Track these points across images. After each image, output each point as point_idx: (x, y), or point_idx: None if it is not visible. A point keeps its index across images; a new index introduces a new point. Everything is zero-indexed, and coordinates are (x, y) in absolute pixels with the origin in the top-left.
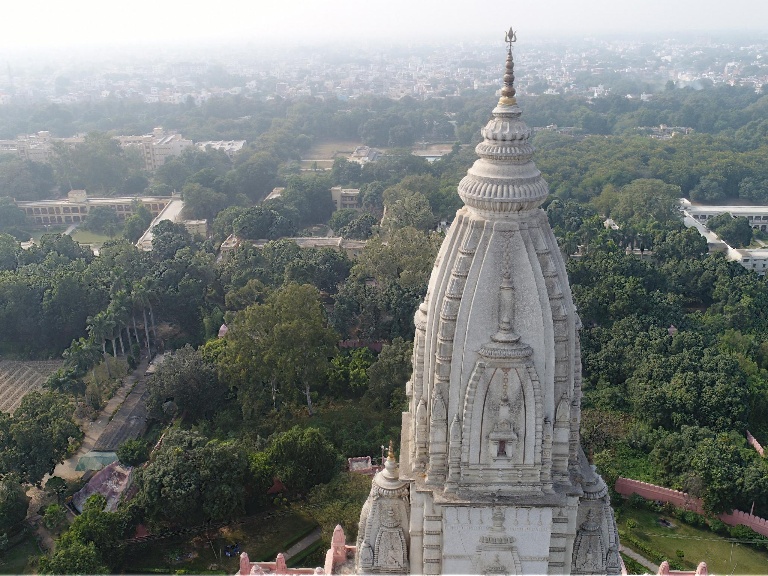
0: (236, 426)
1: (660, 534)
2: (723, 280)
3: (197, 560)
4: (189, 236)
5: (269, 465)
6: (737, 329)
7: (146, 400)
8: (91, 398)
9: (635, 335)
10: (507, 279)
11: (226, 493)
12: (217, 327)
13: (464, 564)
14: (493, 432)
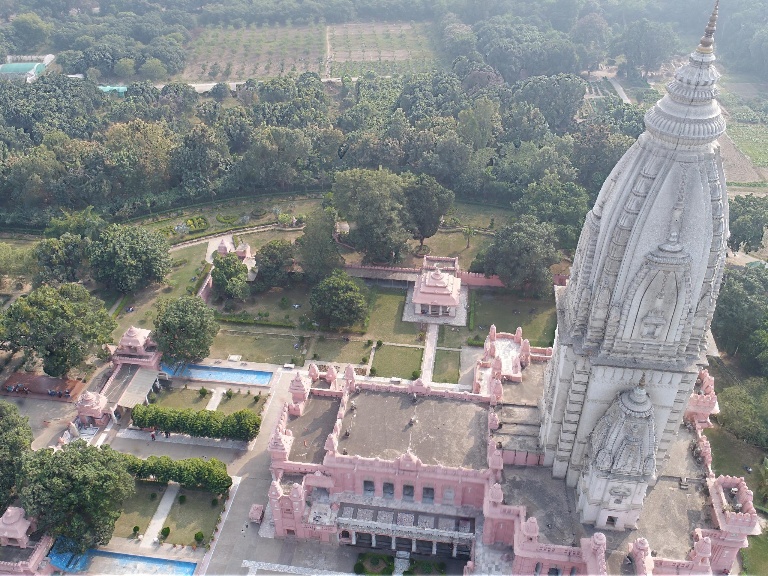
0: None
1: None
2: None
3: None
4: None
5: None
6: None
7: None
8: None
9: None
10: None
11: None
12: None
13: None
14: None
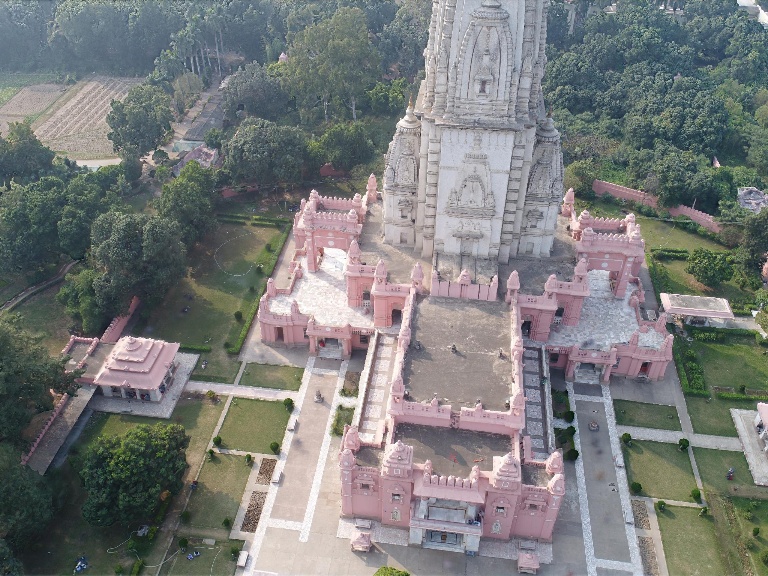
0: None
1: (616, 214)
2: (738, 36)
3: (268, 212)
4: None
5: (322, 149)
6: (739, 82)
7: (223, 104)
8: (177, 103)
9: (642, 78)
10: None
11: (290, 160)
12: (277, 55)
13: (453, 173)
14: (478, 74)
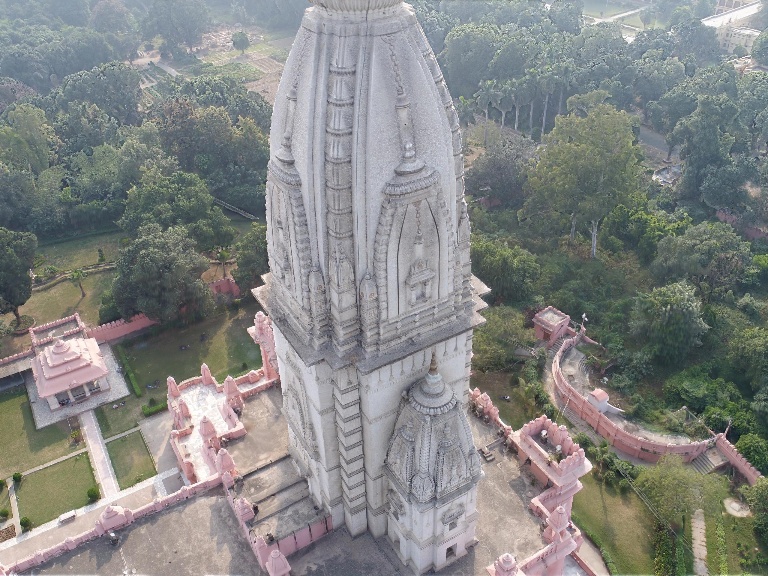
0: (513, 228)
1: None
2: None
3: None
4: (717, 44)
5: None
6: None
7: (468, 170)
8: None
9: None
10: (293, 87)
11: None
12: None
13: None
14: None
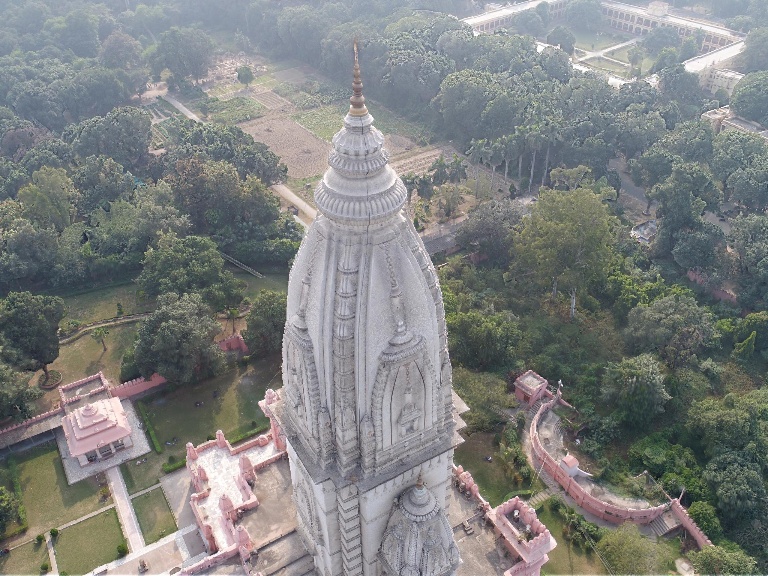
0: (500, 287)
1: None
2: None
3: None
4: (700, 89)
5: (450, 329)
6: None
7: None
8: None
9: None
10: (307, 274)
11: None
12: None
13: None
14: None
